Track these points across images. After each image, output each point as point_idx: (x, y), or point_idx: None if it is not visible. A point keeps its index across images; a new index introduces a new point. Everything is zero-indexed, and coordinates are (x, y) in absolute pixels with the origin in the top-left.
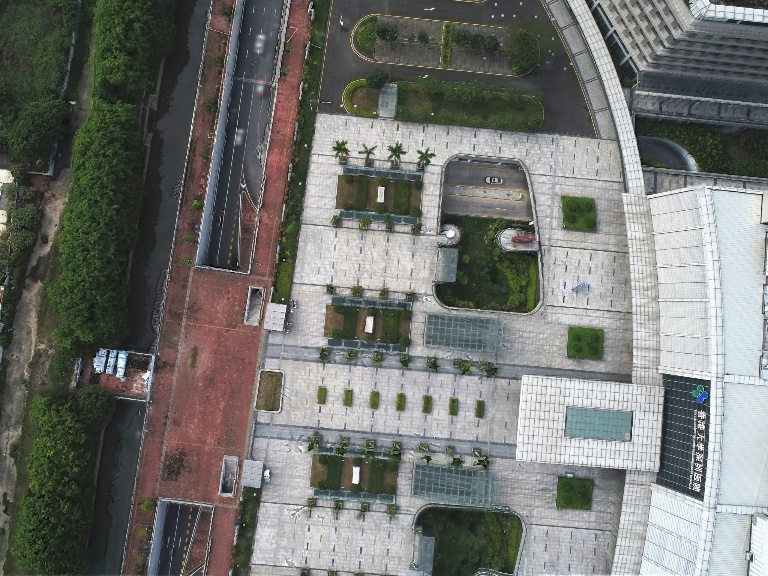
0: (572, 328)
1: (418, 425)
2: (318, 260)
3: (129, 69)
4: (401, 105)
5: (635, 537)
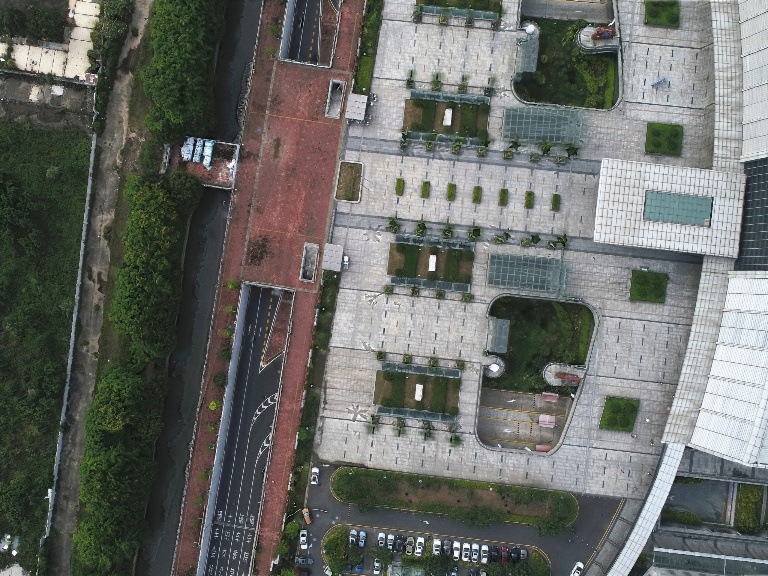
0: (651, 123)
1: (494, 217)
2: (398, 55)
3: None
4: None
5: (710, 324)
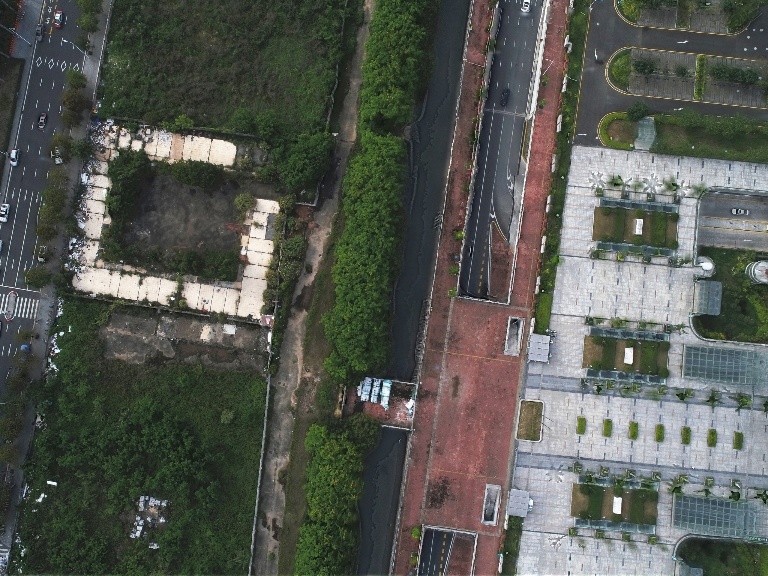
0: None
1: (677, 456)
2: (576, 291)
3: (402, 103)
4: (657, 138)
5: None
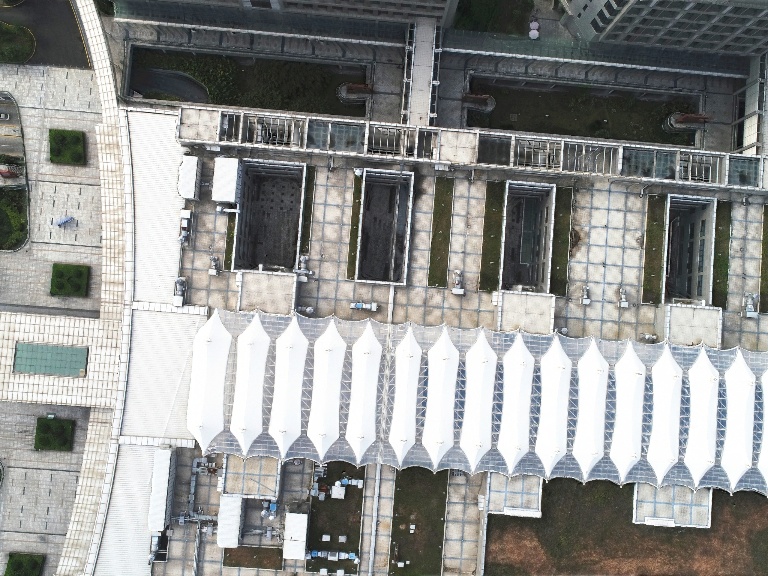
0: (55, 265)
1: None
2: None
3: None
4: None
5: (97, 477)
